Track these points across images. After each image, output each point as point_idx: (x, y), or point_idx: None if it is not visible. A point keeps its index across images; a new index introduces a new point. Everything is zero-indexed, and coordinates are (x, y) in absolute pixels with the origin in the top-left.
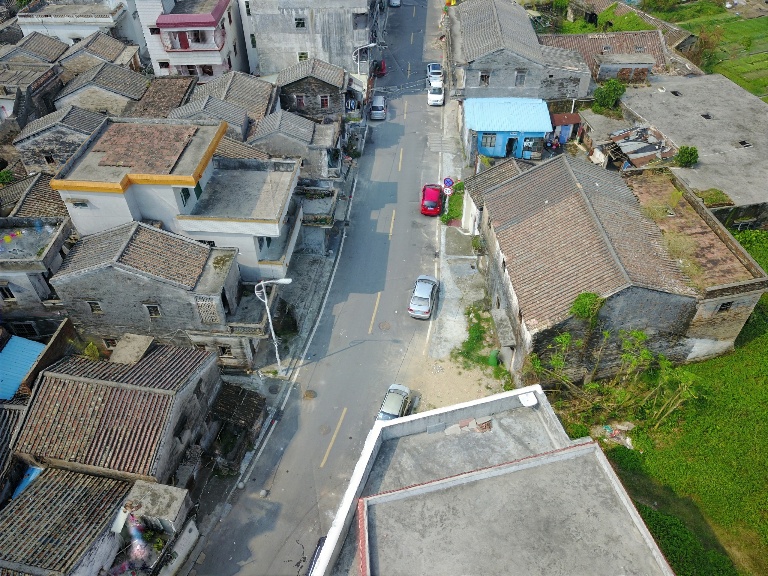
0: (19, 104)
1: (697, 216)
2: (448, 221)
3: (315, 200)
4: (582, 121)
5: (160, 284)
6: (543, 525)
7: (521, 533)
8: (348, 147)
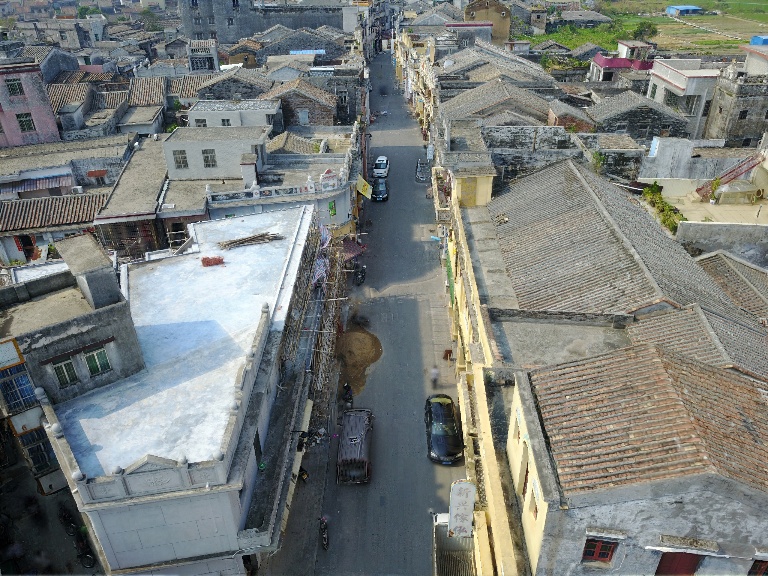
0: None
1: None
2: None
3: None
4: None
5: (425, 7)
6: None
7: None
8: None
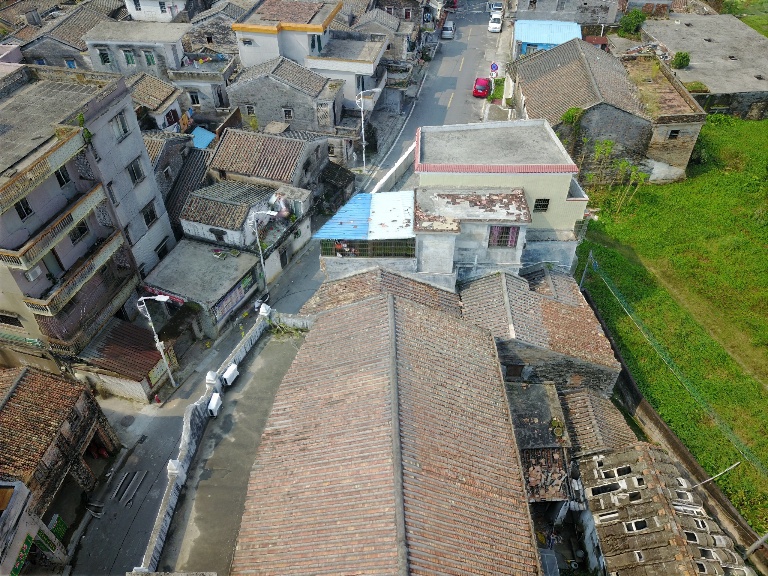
0: (189, 3)
1: (669, 84)
2: (492, 100)
3: (396, 74)
4: (608, 42)
5: (296, 92)
6: (509, 143)
7: (497, 144)
8: (422, 53)
